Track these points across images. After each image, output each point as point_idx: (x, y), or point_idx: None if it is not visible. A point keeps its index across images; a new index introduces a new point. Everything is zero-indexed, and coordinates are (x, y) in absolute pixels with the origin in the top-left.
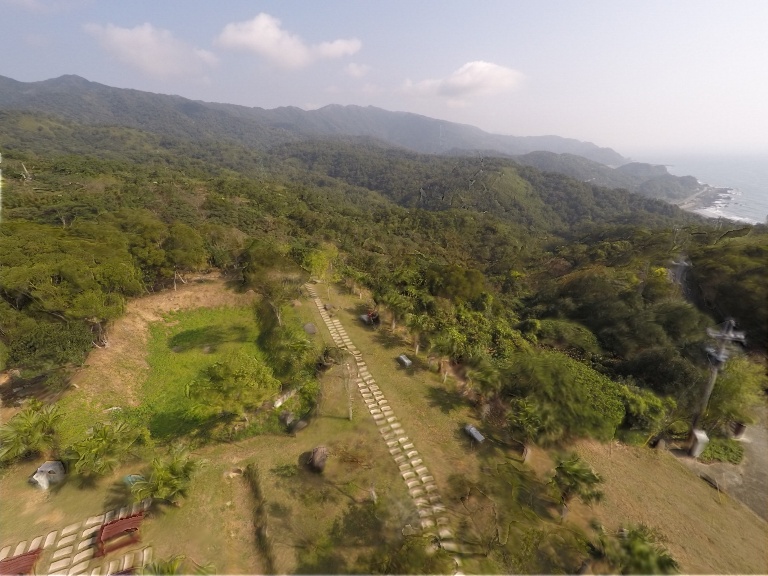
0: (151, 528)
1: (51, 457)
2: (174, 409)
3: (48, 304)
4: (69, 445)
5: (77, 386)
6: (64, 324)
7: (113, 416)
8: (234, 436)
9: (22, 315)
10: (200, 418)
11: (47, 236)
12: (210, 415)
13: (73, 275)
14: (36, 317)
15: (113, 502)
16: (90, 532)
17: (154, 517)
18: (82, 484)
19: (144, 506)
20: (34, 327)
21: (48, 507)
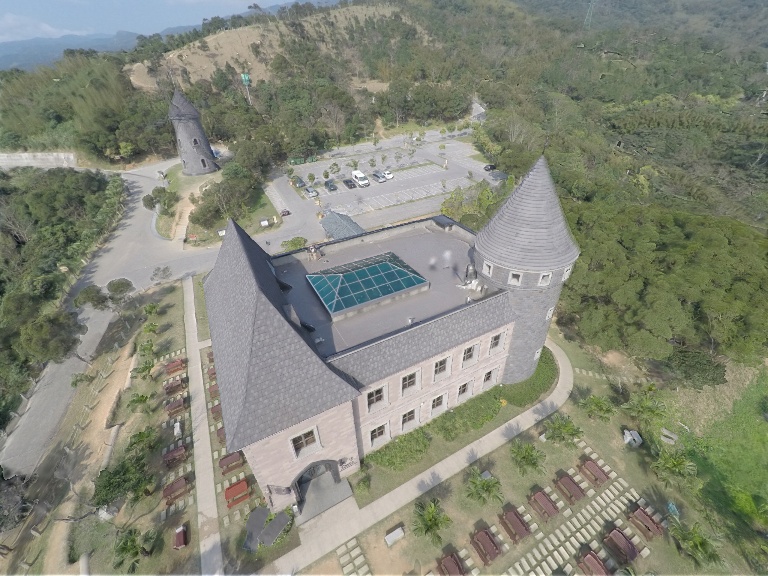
0: (657, 542)
1: (637, 427)
2: (723, 471)
3: (715, 332)
4: (650, 430)
5: (678, 390)
6: (708, 343)
7: (681, 432)
8: (760, 569)
9: (692, 324)
10: (738, 505)
11: (759, 262)
12: (749, 514)
13: (755, 325)
14: (698, 330)
15: (648, 495)
16: (629, 497)
17: (662, 538)
18: (641, 463)
19: (662, 523)
20: (690, 335)
21: (620, 455)
